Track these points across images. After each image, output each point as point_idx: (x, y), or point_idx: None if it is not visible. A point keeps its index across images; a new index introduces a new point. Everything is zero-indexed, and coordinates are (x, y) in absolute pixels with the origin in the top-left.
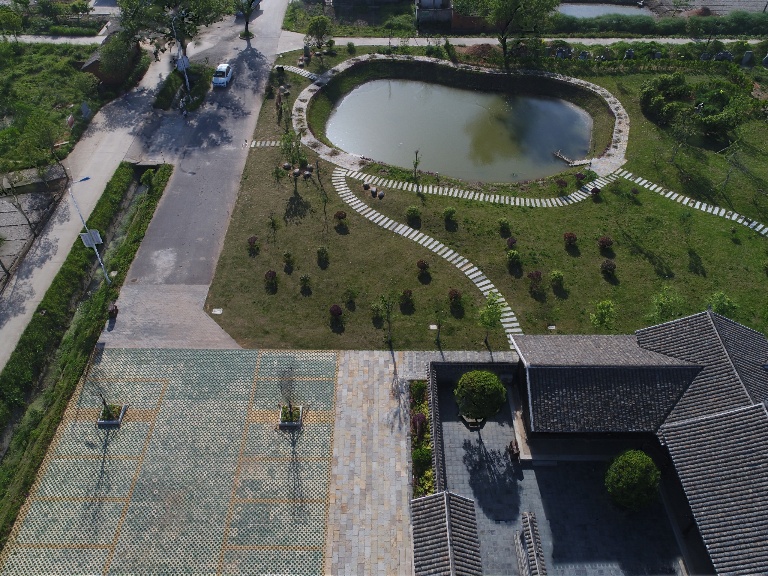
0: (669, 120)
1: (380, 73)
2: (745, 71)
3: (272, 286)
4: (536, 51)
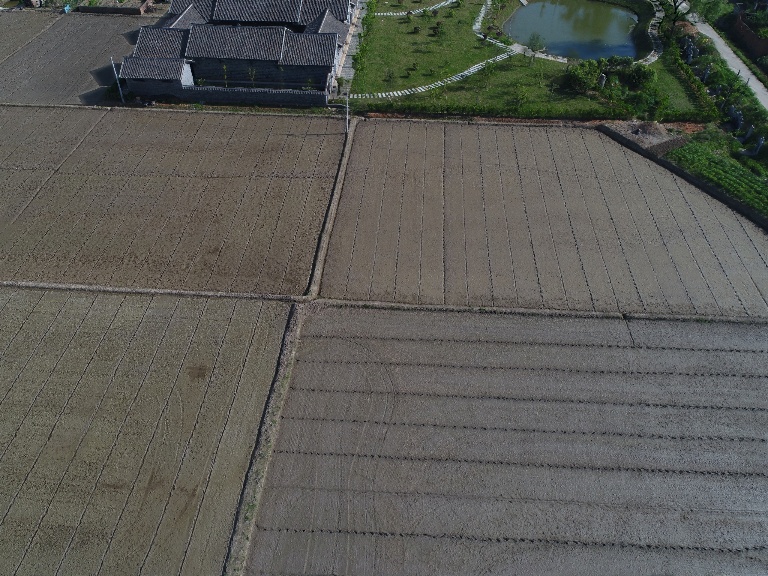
0: None
1: (638, 8)
2: (720, 131)
3: None
4: (685, 39)
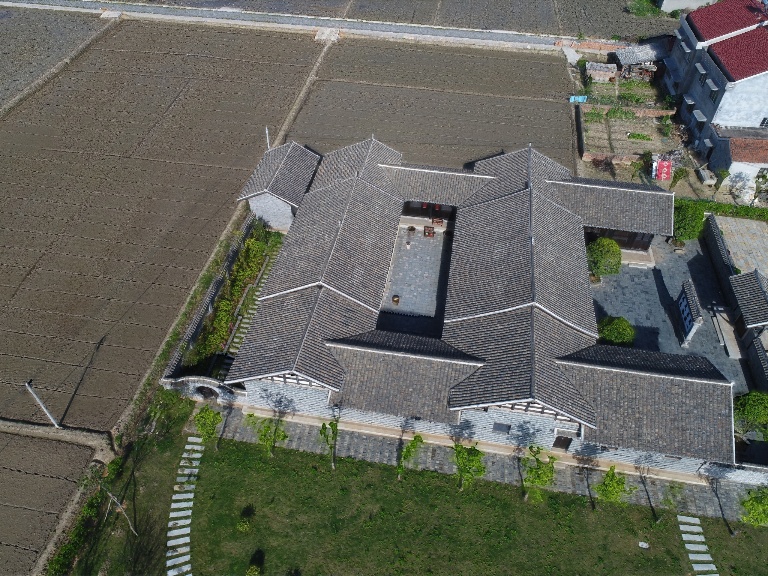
0: None
1: None
2: None
3: None
4: None
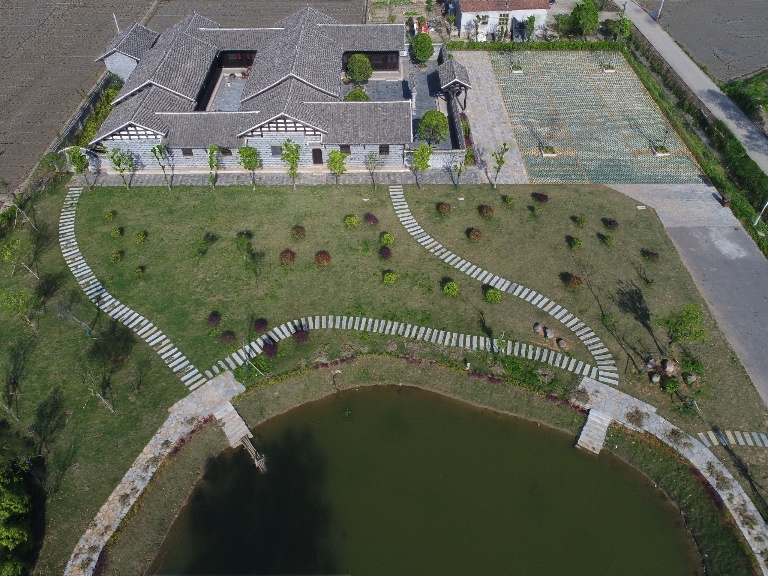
0: (37, 476)
1: None
2: None
3: None
4: None
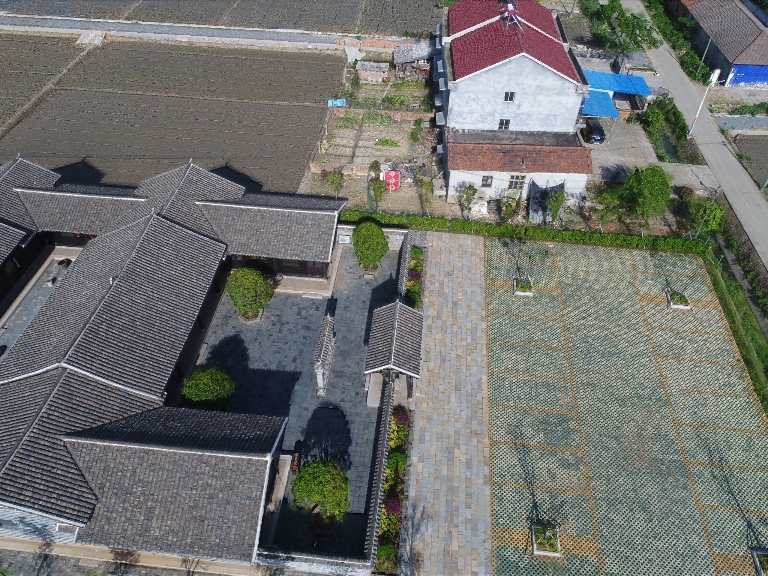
0: None
1: None
2: None
3: None
4: None
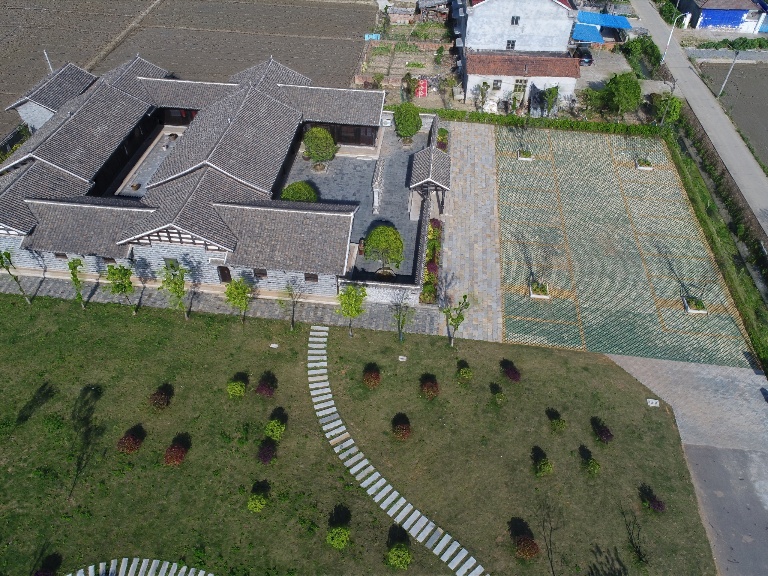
0: None
1: None
2: None
3: (599, 429)
4: None
